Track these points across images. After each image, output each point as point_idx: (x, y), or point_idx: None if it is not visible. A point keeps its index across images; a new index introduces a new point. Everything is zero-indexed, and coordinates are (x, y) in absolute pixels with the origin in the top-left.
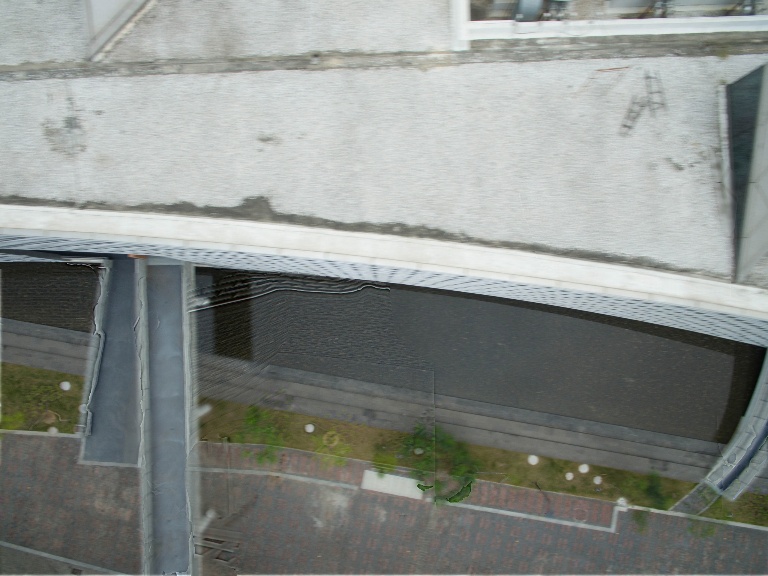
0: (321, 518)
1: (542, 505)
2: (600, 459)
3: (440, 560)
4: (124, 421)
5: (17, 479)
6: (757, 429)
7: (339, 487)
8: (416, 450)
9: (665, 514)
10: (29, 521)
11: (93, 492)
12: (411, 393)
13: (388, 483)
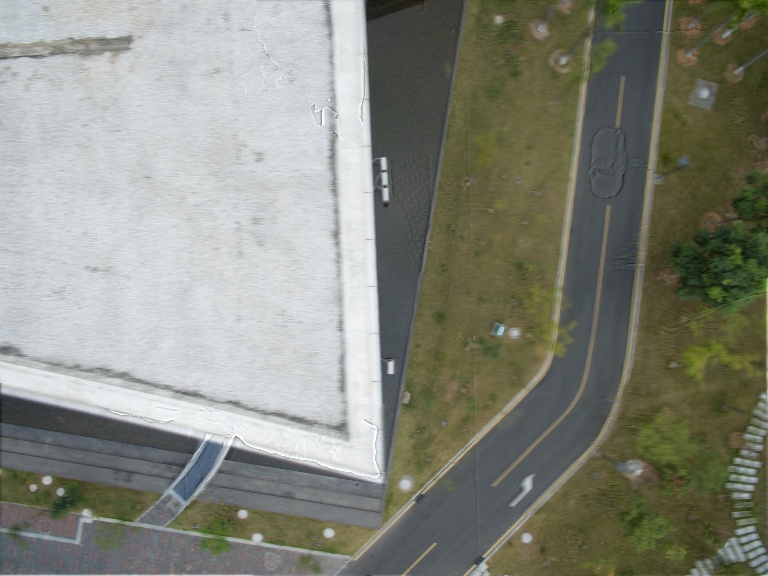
0: None
1: (7, 517)
2: (63, 470)
3: None
4: None
5: None
6: (212, 440)
7: None
8: None
9: (131, 525)
10: None
11: None
12: None
13: None
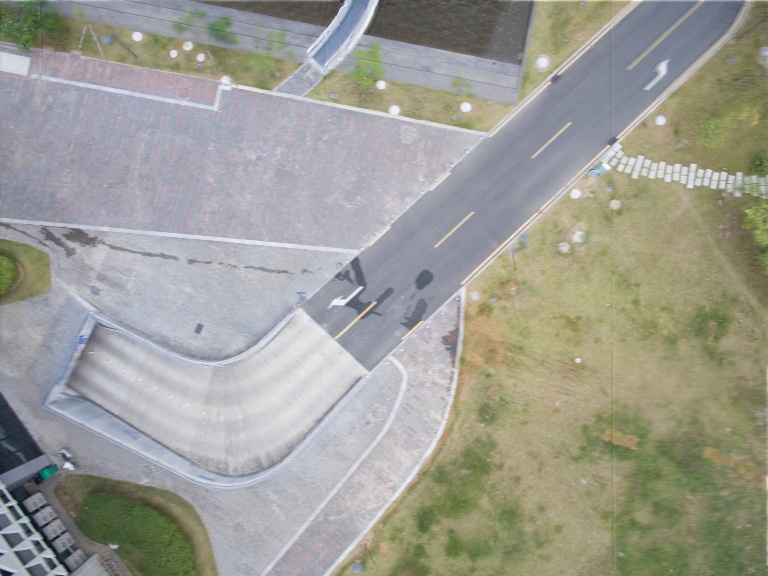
0: None
1: (146, 83)
2: (204, 37)
3: (43, 136)
4: None
5: None
6: None
7: None
8: None
9: (269, 94)
10: None
11: None
12: None
13: None
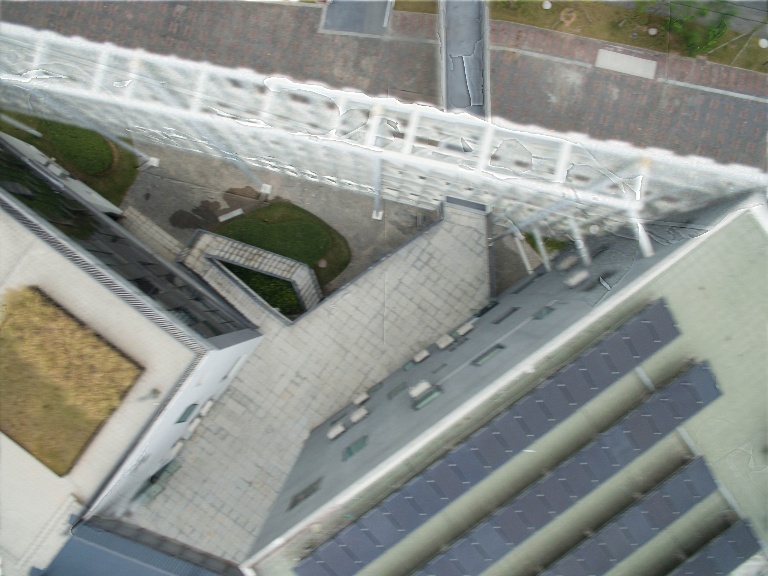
0: (555, 93)
1: None
2: None
3: (670, 138)
4: None
5: (257, 45)
6: None
7: (573, 65)
8: (650, 29)
9: None
10: None
11: (332, 60)
12: None
13: (621, 62)
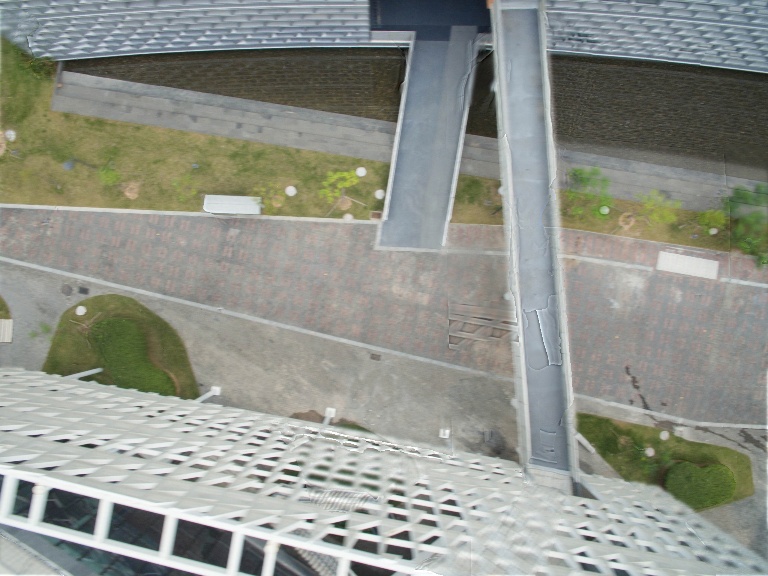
0: (618, 299)
1: None
2: None
3: (736, 339)
4: (422, 205)
5: (313, 266)
6: None
7: (634, 269)
8: (711, 230)
9: None
10: (326, 307)
11: (390, 277)
12: (703, 175)
13: (683, 264)
